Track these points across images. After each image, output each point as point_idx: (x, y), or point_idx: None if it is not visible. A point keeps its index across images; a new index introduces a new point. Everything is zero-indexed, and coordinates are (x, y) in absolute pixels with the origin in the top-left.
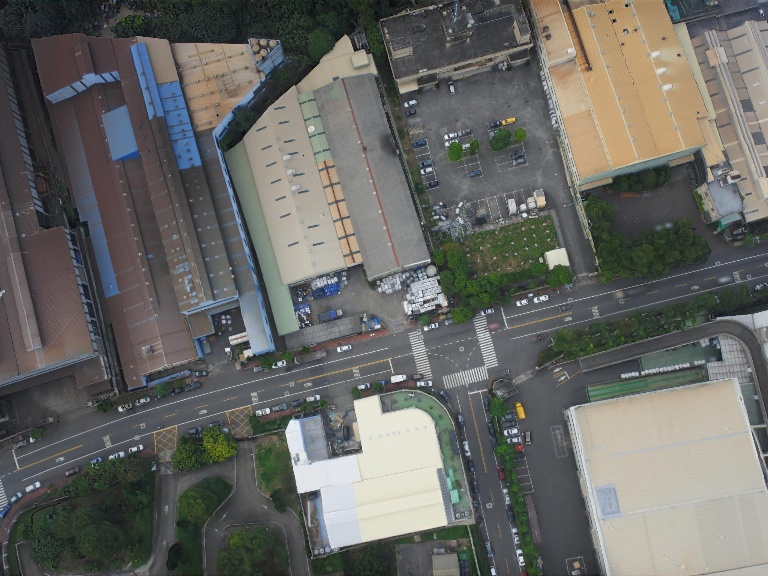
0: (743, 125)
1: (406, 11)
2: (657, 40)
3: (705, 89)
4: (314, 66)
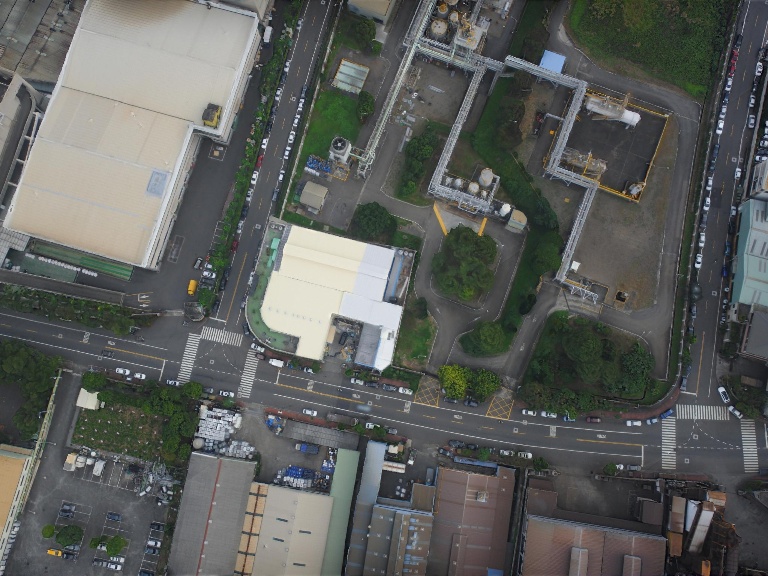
0: None
1: None
2: None
3: None
4: None
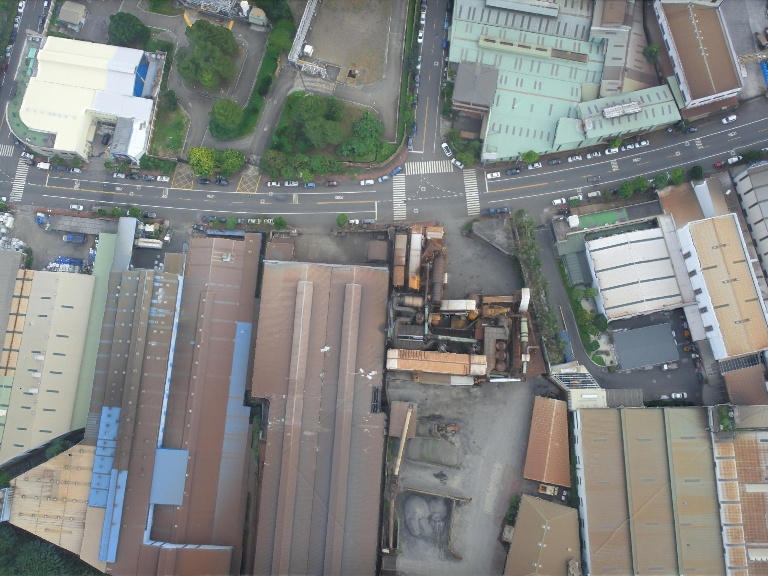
0: None
1: None
2: None
3: None
4: None
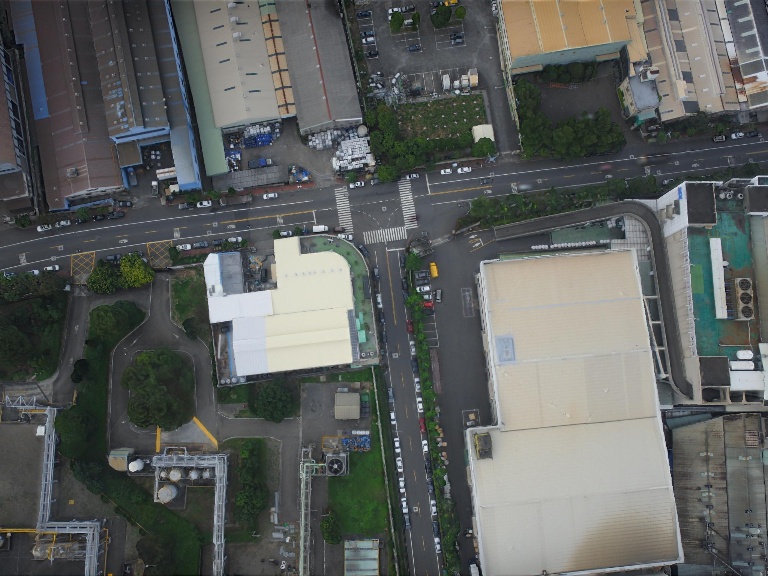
0: (667, 31)
1: None
2: None
3: None
4: None
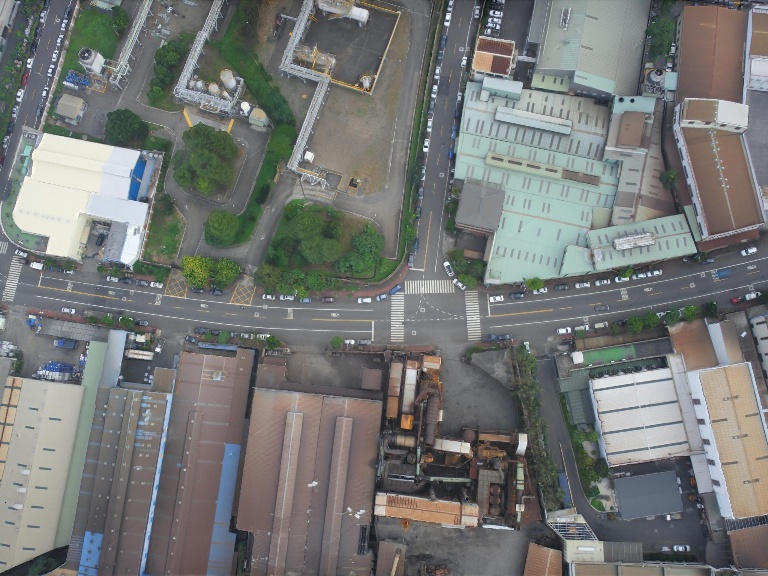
0: None
1: None
2: None
3: None
4: None
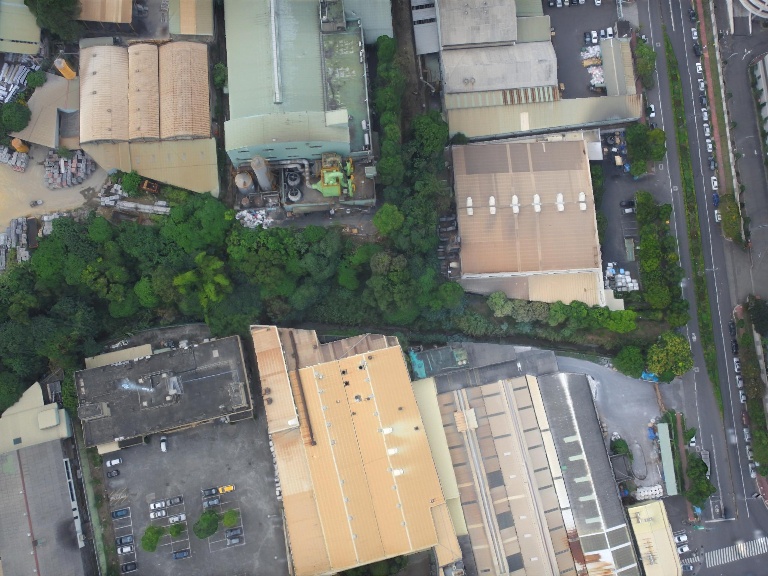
0: (488, 507)
1: (121, 343)
2: (392, 411)
3: (449, 461)
4: (0, 414)
